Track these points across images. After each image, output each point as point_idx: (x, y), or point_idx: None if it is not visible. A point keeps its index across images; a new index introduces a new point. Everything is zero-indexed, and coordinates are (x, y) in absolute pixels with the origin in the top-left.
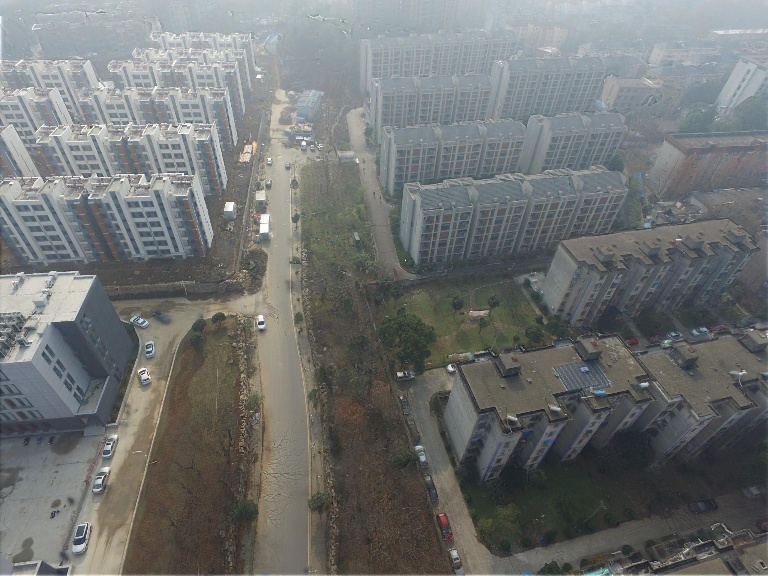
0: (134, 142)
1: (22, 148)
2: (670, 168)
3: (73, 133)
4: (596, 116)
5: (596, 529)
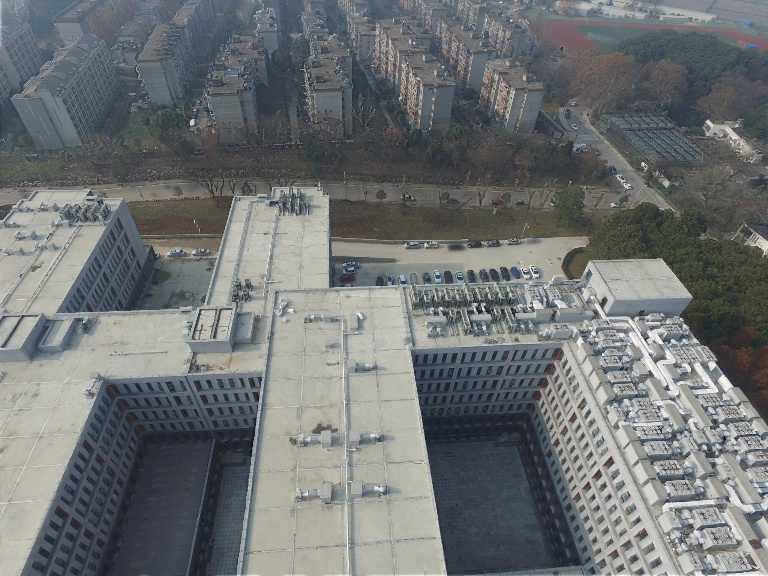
0: None
1: None
2: None
3: None
4: (3, 24)
5: (289, 120)
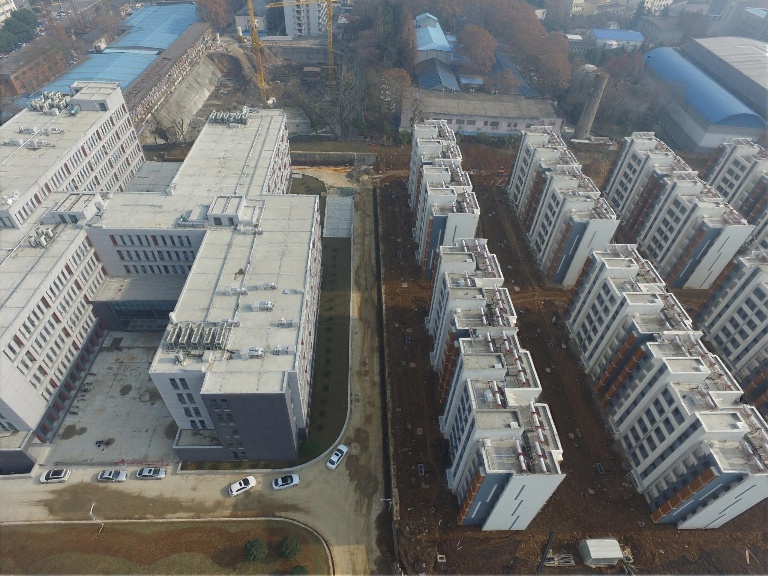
0: (650, 352)
1: (604, 245)
2: None
3: (636, 277)
4: None
5: None
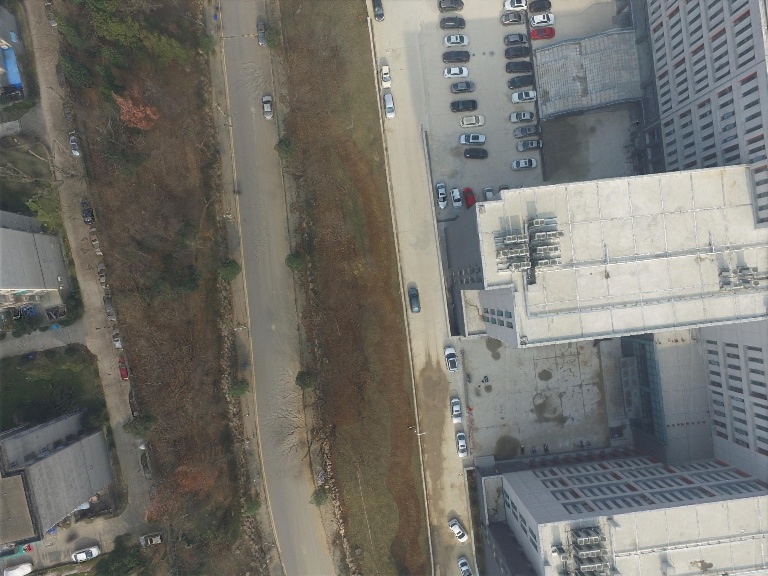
0: None
1: None
2: None
3: None
4: None
5: None
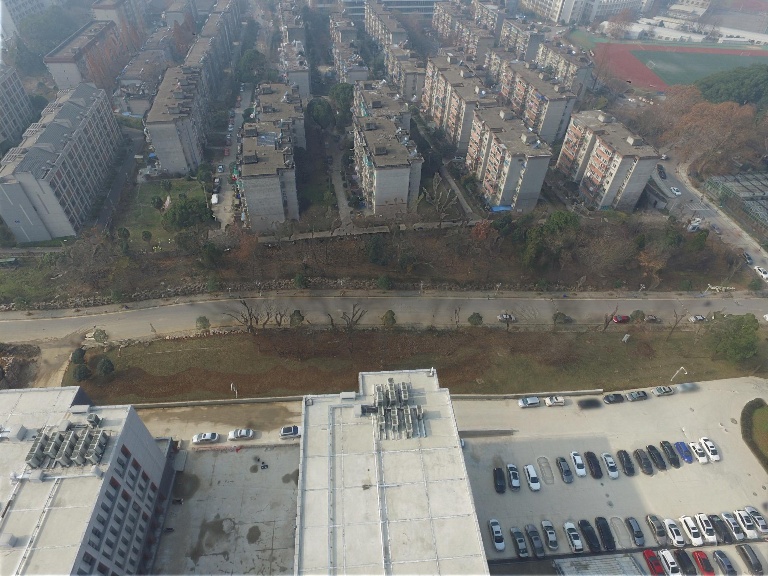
0: None
1: None
2: (74, 80)
3: None
4: None
5: (334, 192)
